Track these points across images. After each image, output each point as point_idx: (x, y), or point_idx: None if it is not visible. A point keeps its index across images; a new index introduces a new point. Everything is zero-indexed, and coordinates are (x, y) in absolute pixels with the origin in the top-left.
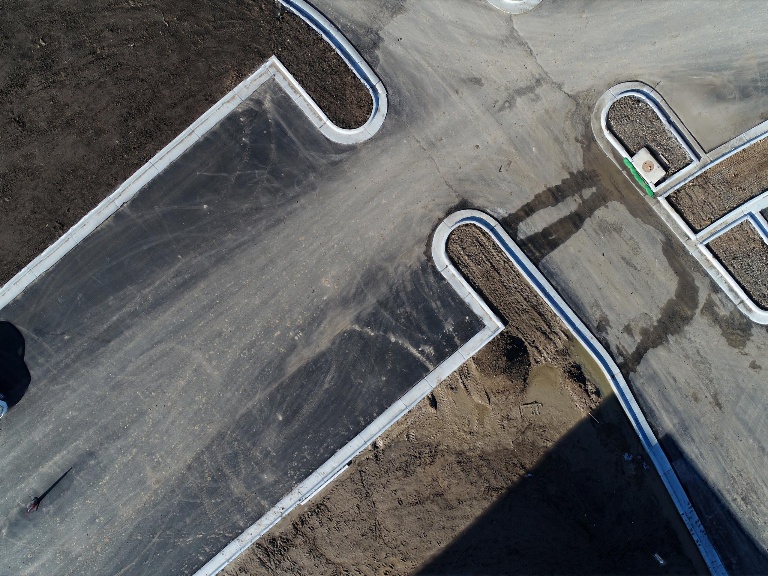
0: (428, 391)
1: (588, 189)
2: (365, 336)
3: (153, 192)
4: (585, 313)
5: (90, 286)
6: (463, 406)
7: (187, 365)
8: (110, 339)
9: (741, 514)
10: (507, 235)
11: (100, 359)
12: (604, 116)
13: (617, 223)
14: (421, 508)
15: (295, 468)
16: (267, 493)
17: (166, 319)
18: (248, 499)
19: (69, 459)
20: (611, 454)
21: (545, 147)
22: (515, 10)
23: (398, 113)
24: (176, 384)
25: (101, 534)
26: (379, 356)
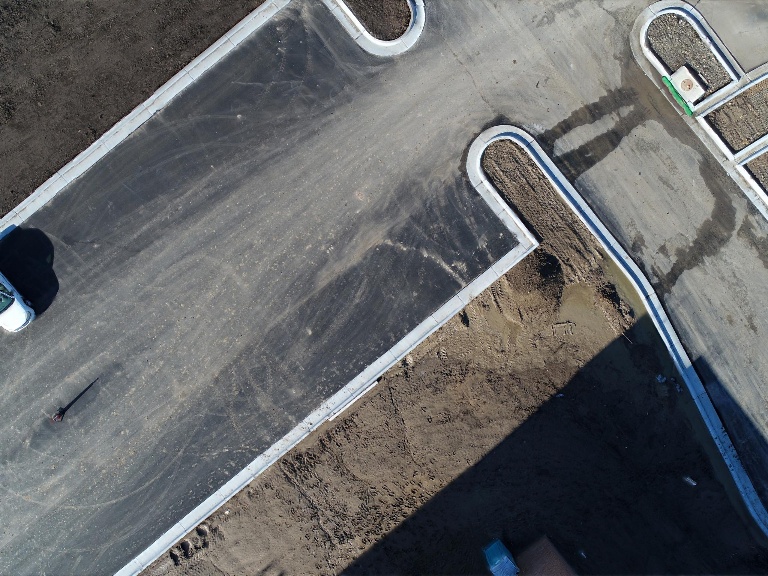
0: (460, 308)
1: (625, 107)
2: (397, 251)
3: (187, 100)
4: (620, 232)
5: (121, 194)
6: (495, 324)
7: (217, 277)
8: (140, 248)
9: None
10: (543, 152)
11: (129, 268)
12: (643, 33)
13: (654, 142)
14: (451, 426)
15: (324, 383)
16: (295, 408)
17: (197, 229)
18: (276, 414)
19: (95, 369)
20: (644, 376)
21: (583, 64)
22: None
23: (435, 26)
24: (205, 296)
25: (126, 447)
26: (411, 271)
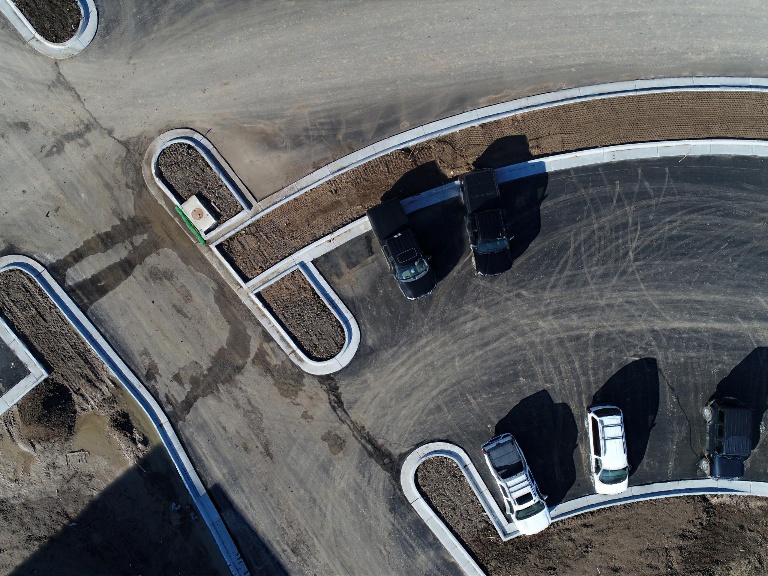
0: None
1: (139, 236)
2: None
3: None
4: (134, 361)
5: None
6: (9, 453)
7: None
8: None
9: (291, 566)
10: (54, 281)
11: None
12: (153, 163)
13: (168, 270)
14: None
15: None
16: None
17: None
18: None
19: None
20: (159, 504)
21: (94, 193)
22: (59, 55)
23: None
24: None
25: None
26: None
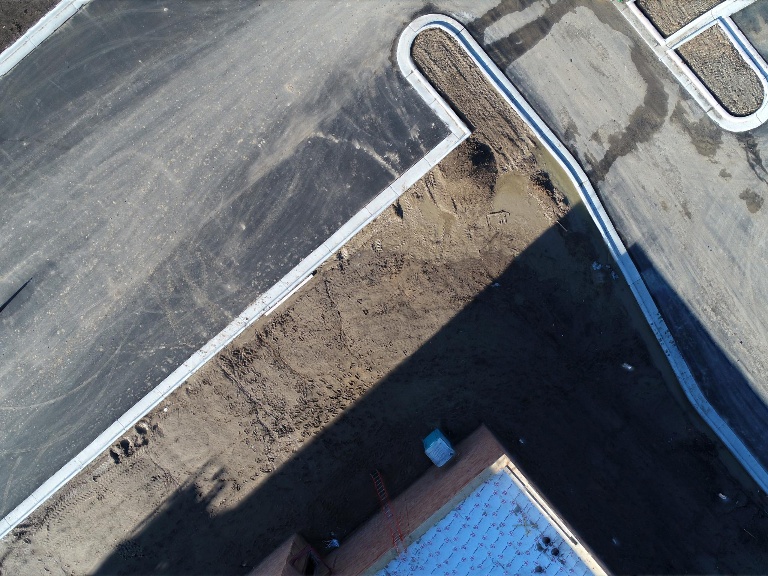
0: (393, 199)
1: None
2: (329, 143)
3: None
4: (553, 120)
5: (49, 91)
6: (429, 215)
7: (148, 173)
8: (70, 146)
9: (711, 325)
10: (473, 40)
11: (60, 166)
12: None
13: (585, 29)
14: (387, 317)
15: (259, 278)
16: (231, 303)
17: (127, 126)
18: (211, 310)
19: (29, 269)
20: (579, 263)
21: None
22: None
23: None
24: (137, 192)
25: (62, 346)
26: (344, 164)
